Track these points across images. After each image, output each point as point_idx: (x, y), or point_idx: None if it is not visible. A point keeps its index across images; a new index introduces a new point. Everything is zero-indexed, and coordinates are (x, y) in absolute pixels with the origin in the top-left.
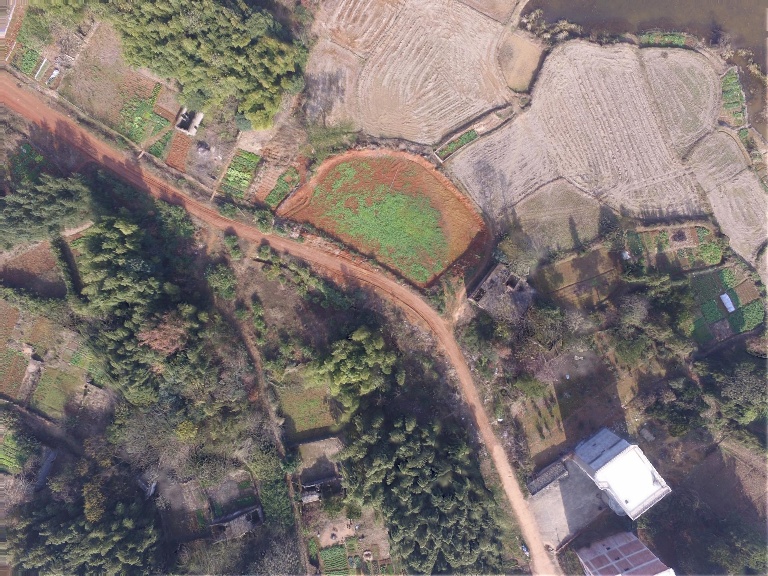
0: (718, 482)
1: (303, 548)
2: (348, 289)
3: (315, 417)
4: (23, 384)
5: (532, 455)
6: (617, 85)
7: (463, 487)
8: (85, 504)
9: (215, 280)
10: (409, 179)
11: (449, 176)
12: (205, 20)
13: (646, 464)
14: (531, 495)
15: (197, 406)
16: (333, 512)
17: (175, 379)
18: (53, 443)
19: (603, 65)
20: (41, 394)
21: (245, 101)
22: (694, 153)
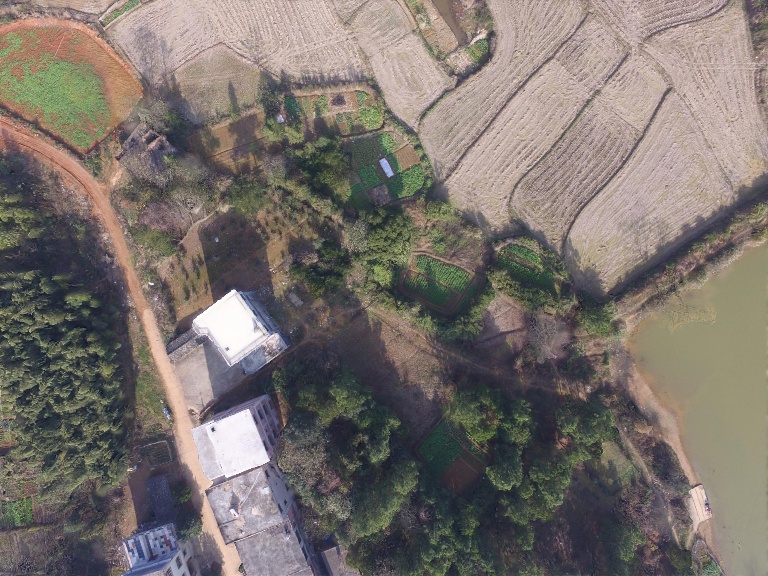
0: (362, 346)
1: None
2: (8, 154)
3: None
4: None
5: (180, 318)
6: None
7: (68, 332)
8: None
9: None
10: (74, 47)
11: (111, 43)
12: None
13: (248, 311)
14: None
15: None
16: None
17: None
18: None
19: None
20: None
21: None
22: (357, 18)
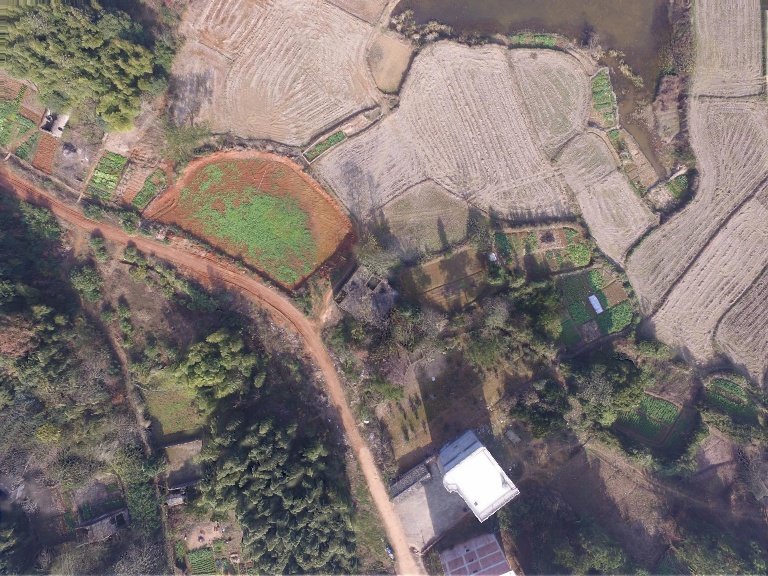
0: (582, 483)
1: (170, 551)
2: (214, 291)
3: (182, 420)
4: None
5: (398, 457)
6: (486, 86)
7: (313, 490)
8: None
9: (79, 282)
10: (277, 181)
11: (317, 178)
12: (54, 21)
13: (495, 466)
14: None
15: (58, 409)
16: (200, 515)
17: (27, 382)
18: None
19: (472, 66)
20: None
21: (100, 103)
22: (563, 154)
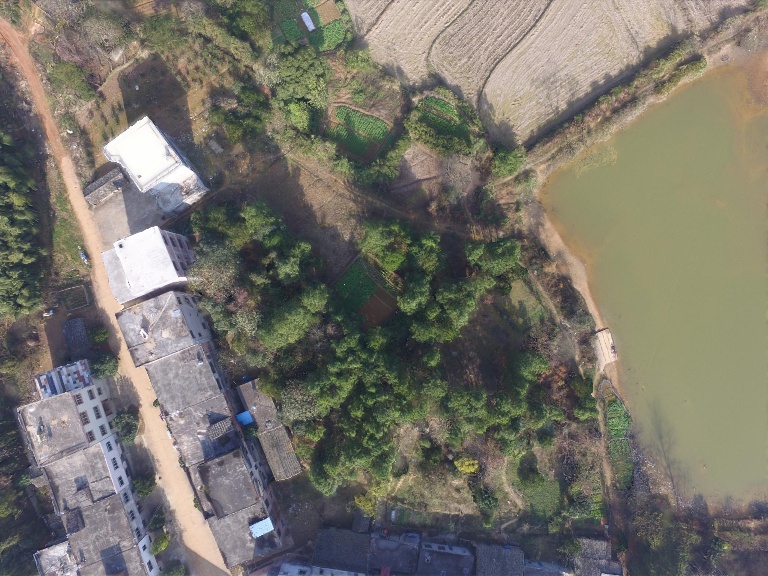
0: (281, 191)
1: None
2: None
3: None
4: None
5: (98, 165)
6: None
7: None
8: None
9: None
10: None
11: None
12: None
13: (160, 139)
14: None
15: None
16: None
17: None
18: None
19: None
20: None
21: None
22: None
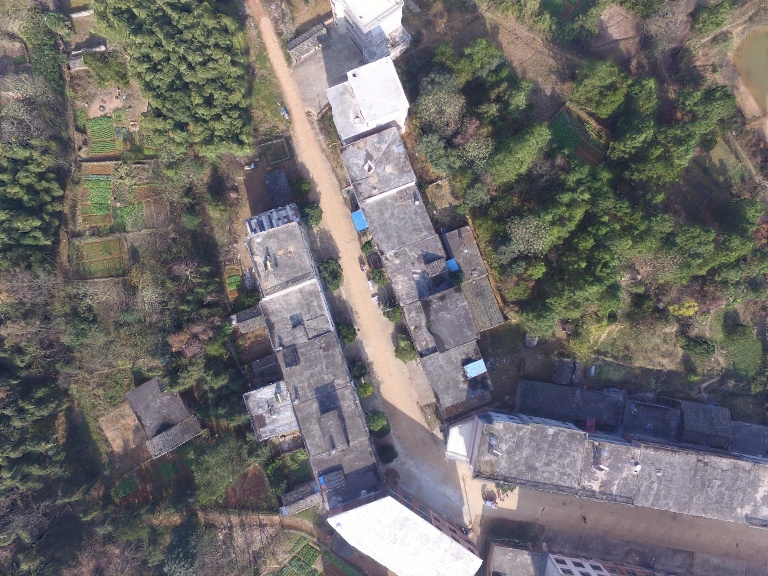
0: None
1: (72, 119)
2: None
3: None
4: None
5: (297, 25)
6: None
7: (201, 3)
8: None
9: None
10: None
11: None
12: None
13: None
14: (293, 60)
15: None
16: (102, 83)
17: None
18: None
19: None
20: None
21: None
22: None
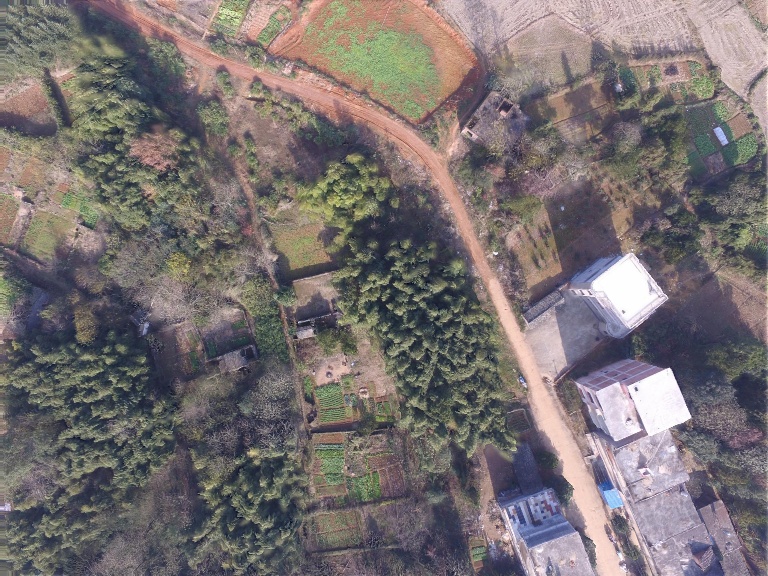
0: (715, 310)
1: (298, 387)
2: (341, 125)
3: (309, 254)
4: (13, 228)
5: (528, 287)
6: None
7: (459, 300)
8: (76, 332)
9: (207, 115)
10: (401, 17)
11: (441, 13)
12: None
13: (642, 273)
14: (528, 326)
15: (189, 238)
16: (328, 349)
17: (167, 200)
18: (44, 285)
19: None
20: (32, 238)
21: None
22: None
